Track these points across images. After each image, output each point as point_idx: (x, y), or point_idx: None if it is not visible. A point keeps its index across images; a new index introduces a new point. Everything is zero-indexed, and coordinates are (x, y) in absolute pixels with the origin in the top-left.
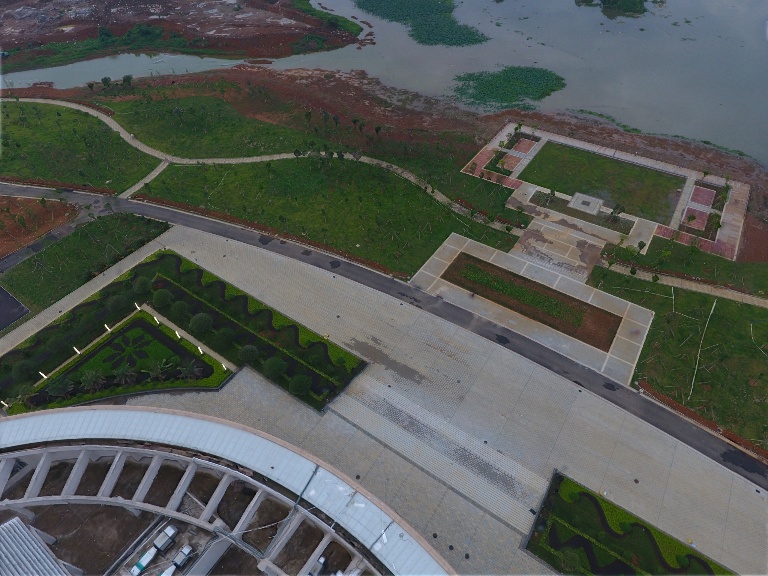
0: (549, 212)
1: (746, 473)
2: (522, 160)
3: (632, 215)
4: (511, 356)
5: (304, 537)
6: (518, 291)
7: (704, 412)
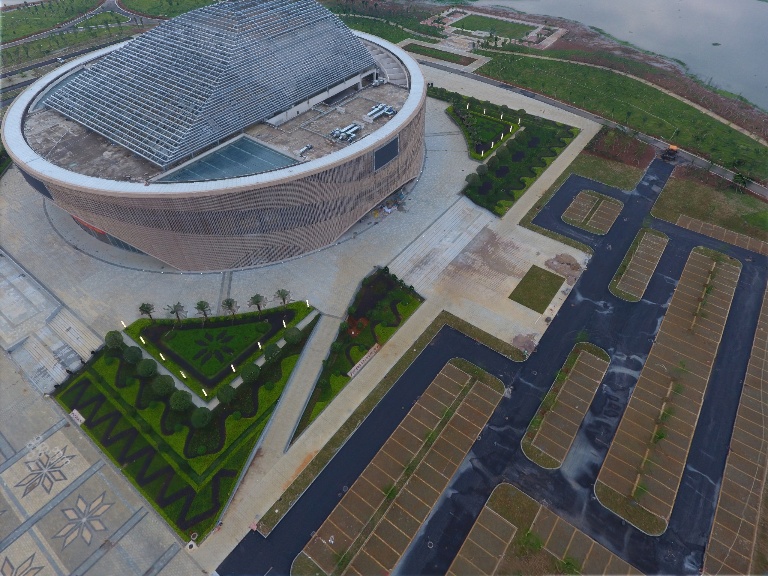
0: (460, 35)
1: (505, 88)
2: (454, 20)
3: (502, 37)
4: (424, 66)
5: None
6: (434, 52)
7: (498, 77)
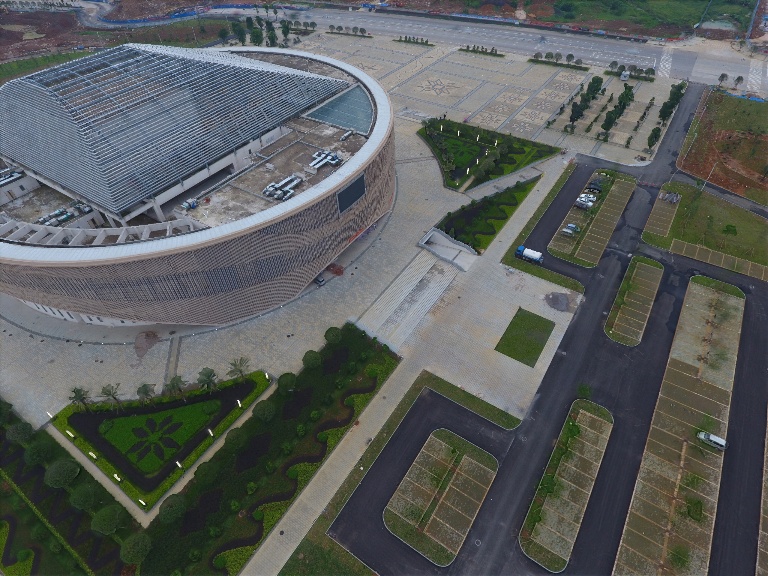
0: None
1: None
2: None
3: None
4: None
5: None
6: None
7: None
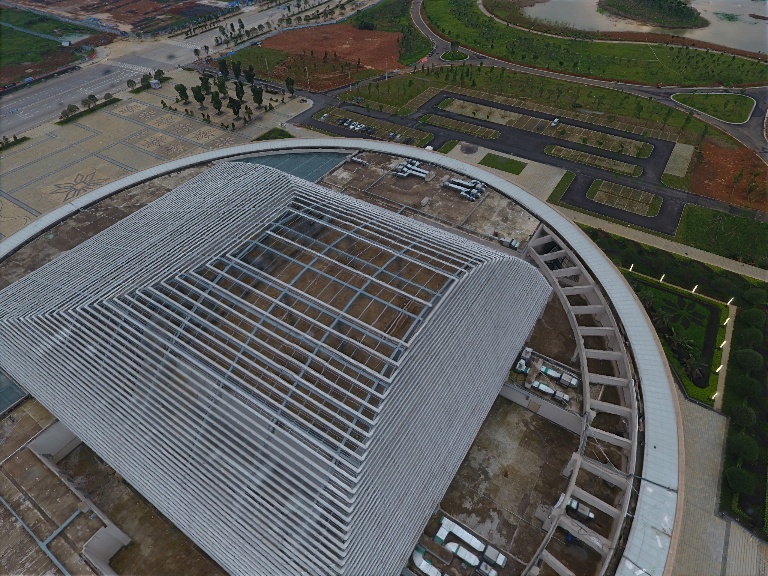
0: None
1: None
2: None
3: None
4: None
5: (603, 496)
6: None
7: None
